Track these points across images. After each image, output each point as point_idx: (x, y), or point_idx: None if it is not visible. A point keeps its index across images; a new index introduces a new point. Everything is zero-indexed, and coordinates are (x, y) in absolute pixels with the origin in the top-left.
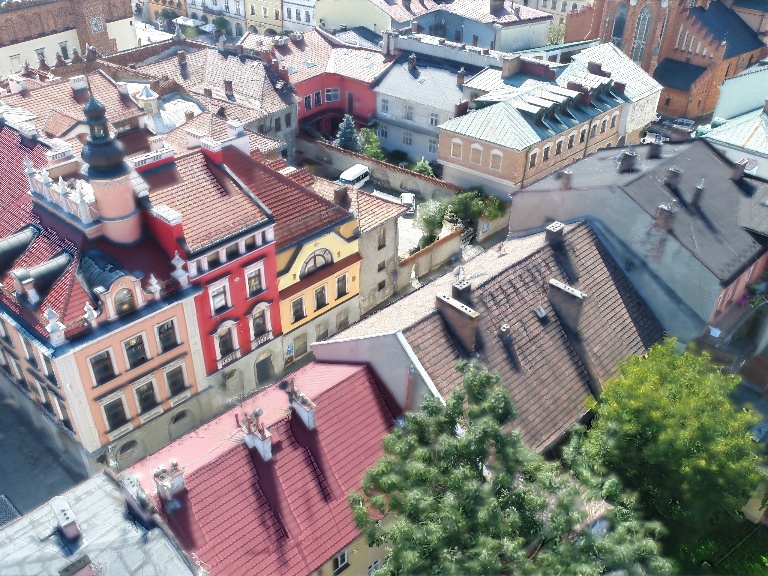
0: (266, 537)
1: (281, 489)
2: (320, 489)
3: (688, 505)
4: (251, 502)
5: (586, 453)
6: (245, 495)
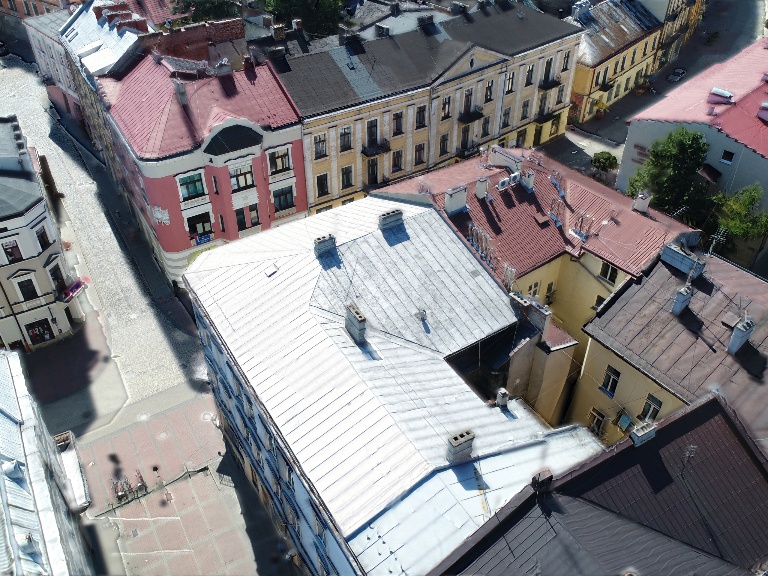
0: (139, 13)
1: (144, 2)
2: (160, 5)
3: (296, 5)
4: (133, 3)
5: (268, 1)
6: (131, 1)
